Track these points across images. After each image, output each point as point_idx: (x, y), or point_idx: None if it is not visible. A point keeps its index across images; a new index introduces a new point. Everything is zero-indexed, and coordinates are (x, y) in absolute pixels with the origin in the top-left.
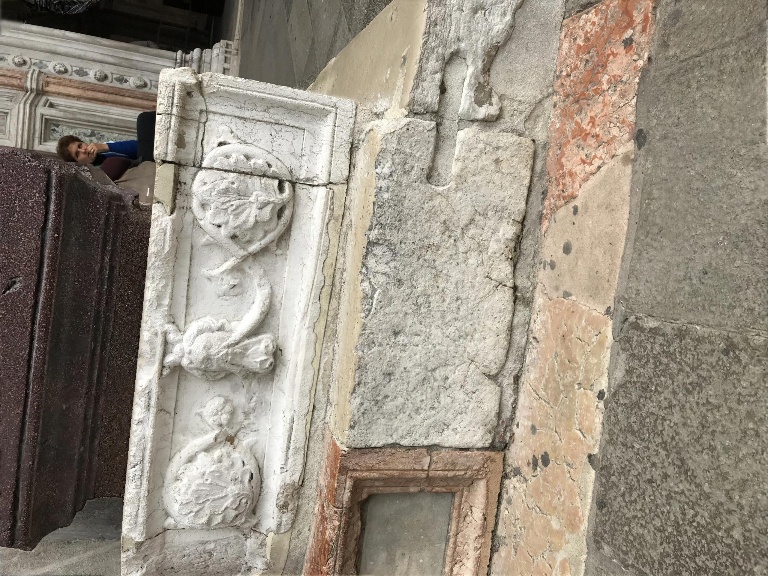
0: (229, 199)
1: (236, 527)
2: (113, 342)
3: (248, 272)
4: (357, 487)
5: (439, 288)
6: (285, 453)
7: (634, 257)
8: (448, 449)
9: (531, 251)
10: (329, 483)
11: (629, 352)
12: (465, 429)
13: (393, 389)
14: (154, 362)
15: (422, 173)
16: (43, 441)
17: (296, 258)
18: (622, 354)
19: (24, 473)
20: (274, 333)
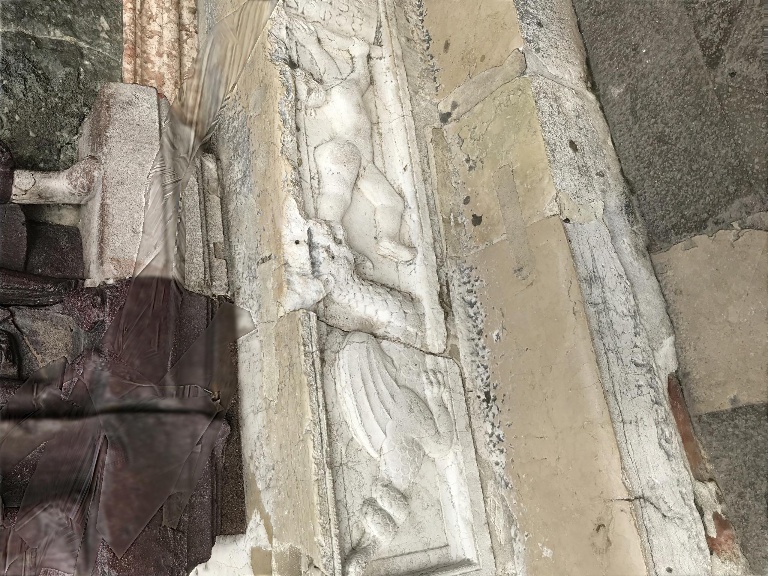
0: None
1: None
2: None
3: None
4: None
5: None
6: None
7: None
8: None
9: None
10: None
11: None
12: None
13: None
14: None
15: None
16: None
17: None
18: None
19: None
20: None
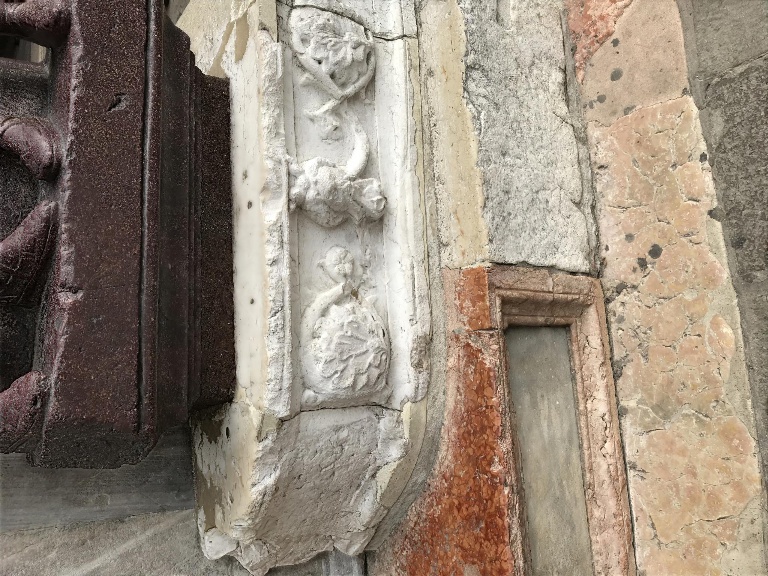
0: (327, 35)
1: (367, 407)
2: (203, 205)
3: (345, 117)
4: None
5: (525, 117)
6: (412, 302)
7: (699, 37)
8: (562, 272)
9: (574, 98)
10: (474, 312)
11: (723, 106)
12: (570, 253)
13: (513, 207)
14: (281, 193)
15: (493, 14)
16: None
17: (384, 107)
18: (715, 112)
19: (146, 332)
20: None
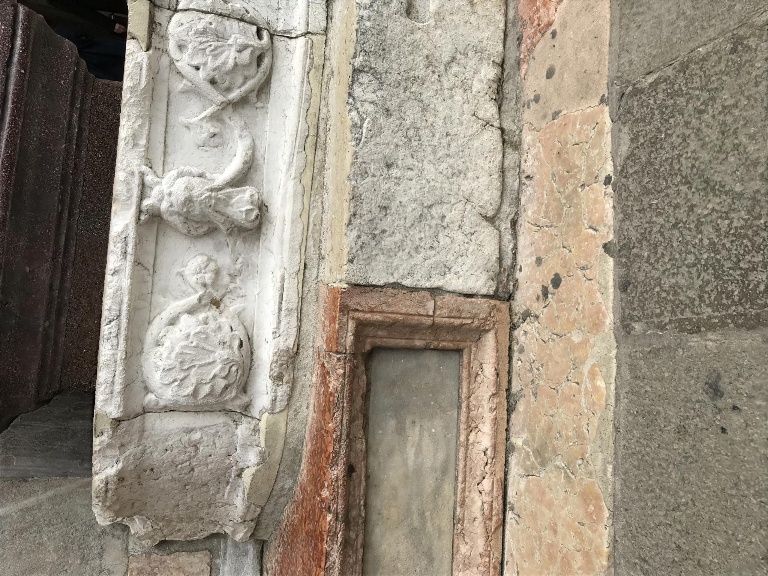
0: (207, 39)
1: (225, 412)
2: (82, 209)
3: (228, 123)
4: (359, 334)
5: (428, 122)
6: (277, 315)
7: (622, 34)
8: (452, 294)
9: (513, 96)
10: (329, 333)
11: (631, 121)
12: (467, 273)
13: (390, 223)
14: (131, 205)
15: (401, 6)
16: (3, 302)
17: (278, 110)
18: (624, 127)
19: None
20: (258, 189)
